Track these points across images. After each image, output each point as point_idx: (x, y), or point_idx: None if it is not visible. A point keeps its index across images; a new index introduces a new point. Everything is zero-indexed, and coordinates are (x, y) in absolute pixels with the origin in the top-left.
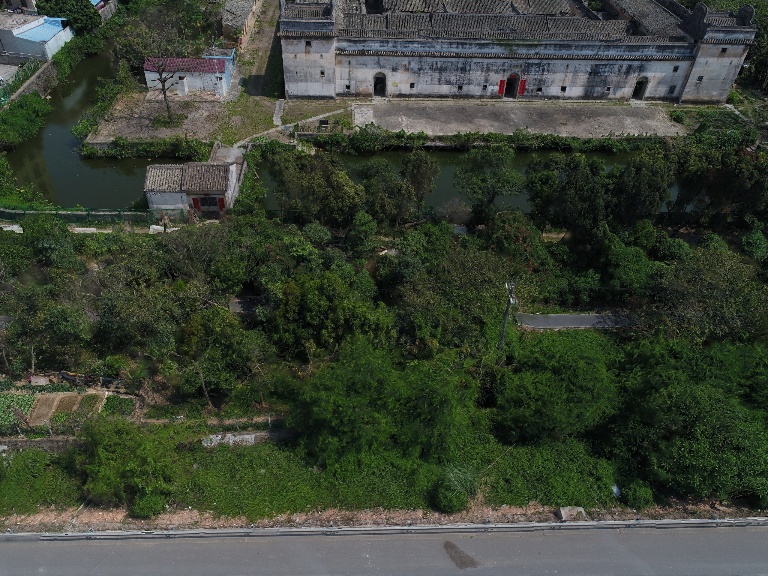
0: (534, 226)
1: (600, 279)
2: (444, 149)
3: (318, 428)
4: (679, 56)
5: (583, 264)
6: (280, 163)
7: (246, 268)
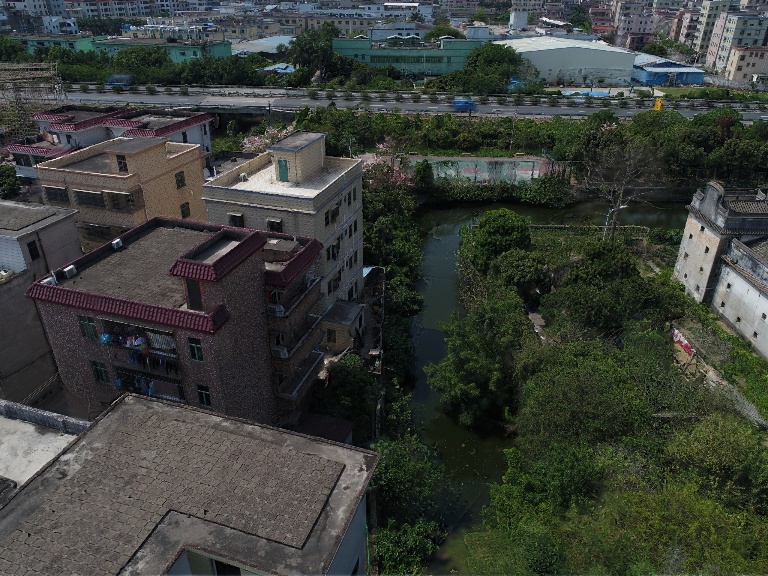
0: None
1: None
2: None
3: None
4: None
5: None
6: None
7: None
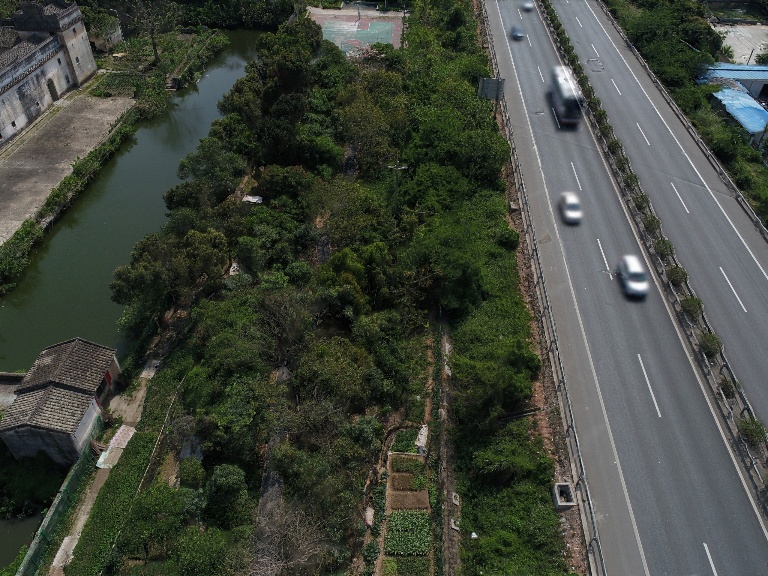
0: (280, 168)
1: (329, 165)
2: (55, 221)
3: (464, 288)
4: (55, 50)
5: (307, 170)
6: (145, 273)
7: (268, 335)
